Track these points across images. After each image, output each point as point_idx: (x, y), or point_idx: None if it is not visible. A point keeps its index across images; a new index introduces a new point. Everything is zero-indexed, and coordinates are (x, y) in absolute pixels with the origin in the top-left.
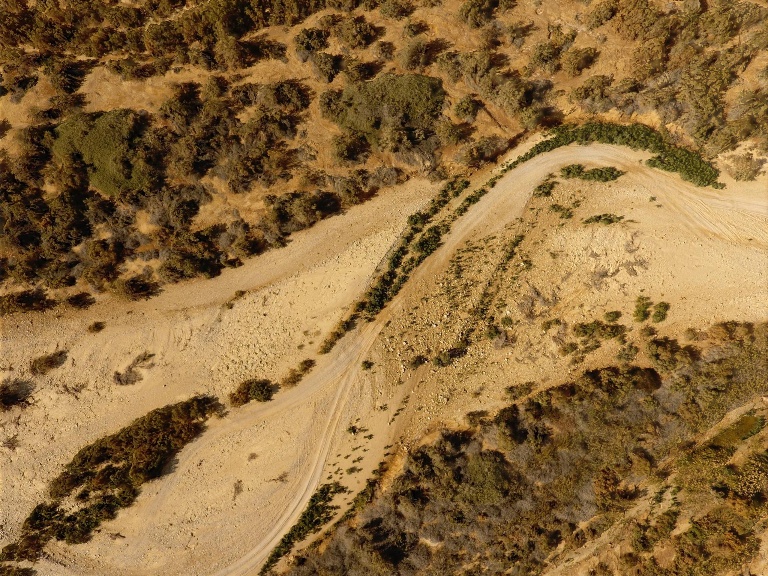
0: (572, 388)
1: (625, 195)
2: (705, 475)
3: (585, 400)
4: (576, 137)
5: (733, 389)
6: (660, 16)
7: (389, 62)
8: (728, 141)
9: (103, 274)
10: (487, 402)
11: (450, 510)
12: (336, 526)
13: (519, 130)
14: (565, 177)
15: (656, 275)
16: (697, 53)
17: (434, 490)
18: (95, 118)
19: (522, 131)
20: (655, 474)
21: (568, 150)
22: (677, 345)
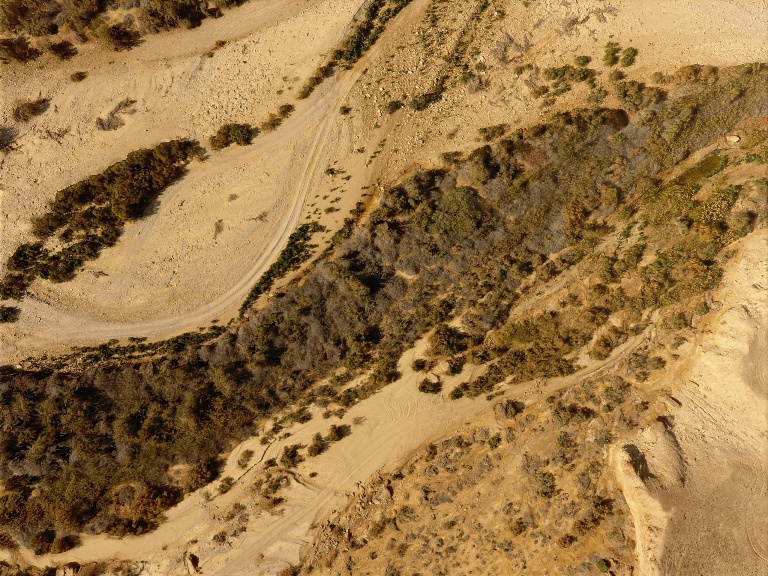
0: (543, 127)
1: None
2: (670, 208)
3: (555, 133)
4: None
5: (697, 123)
6: None
7: None
8: None
9: (85, 21)
10: (461, 143)
11: (425, 242)
12: (315, 262)
13: None
14: None
15: (625, 21)
16: None
17: (409, 221)
18: None
19: None
20: (623, 208)
21: None
22: None
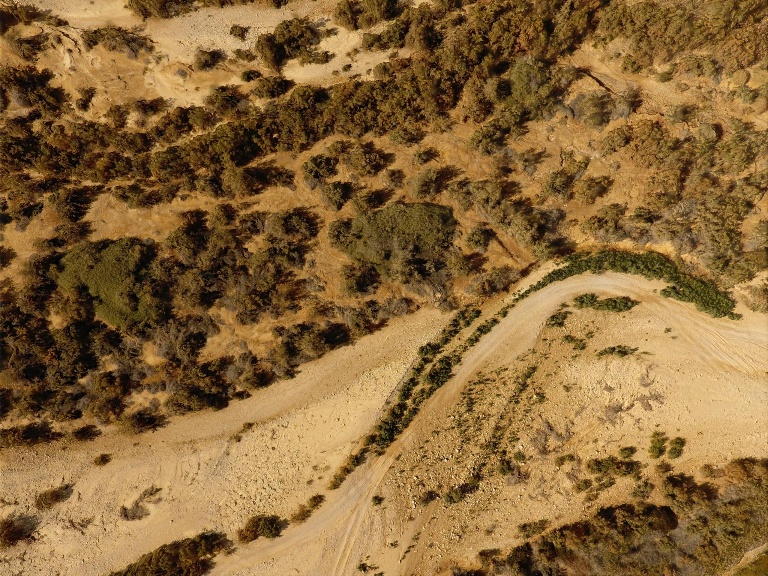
0: (586, 527)
1: (639, 326)
2: None
3: (600, 543)
4: (589, 267)
5: (751, 531)
6: (675, 148)
7: (399, 190)
8: (745, 276)
9: (109, 408)
10: (500, 540)
11: None
12: None
13: (531, 260)
14: (578, 307)
15: (672, 410)
16: (713, 184)
17: None
18: (101, 250)
19: (534, 261)
20: None
21: (581, 279)
22: (693, 482)
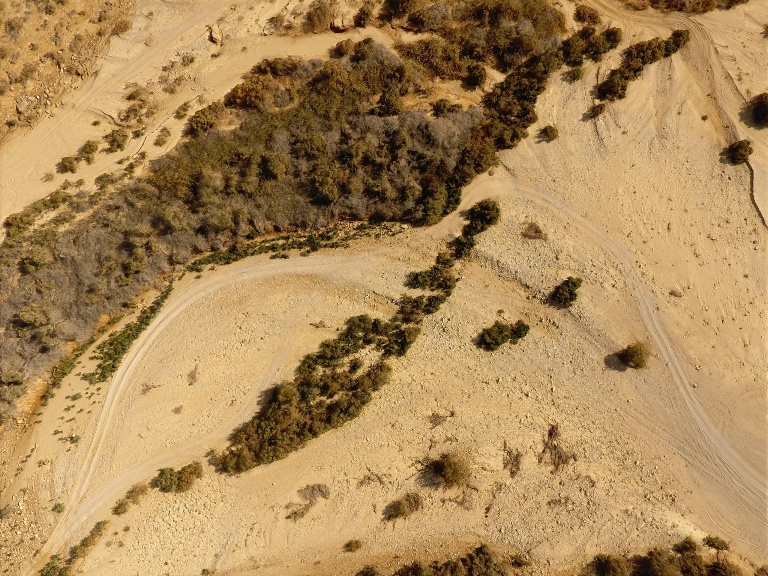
0: None
1: None
2: None
3: None
4: None
5: None
6: None
7: None
8: None
9: None
10: None
11: None
12: (92, 340)
13: None
14: None
15: None
16: None
17: None
18: None
19: None
20: None
21: None
22: None
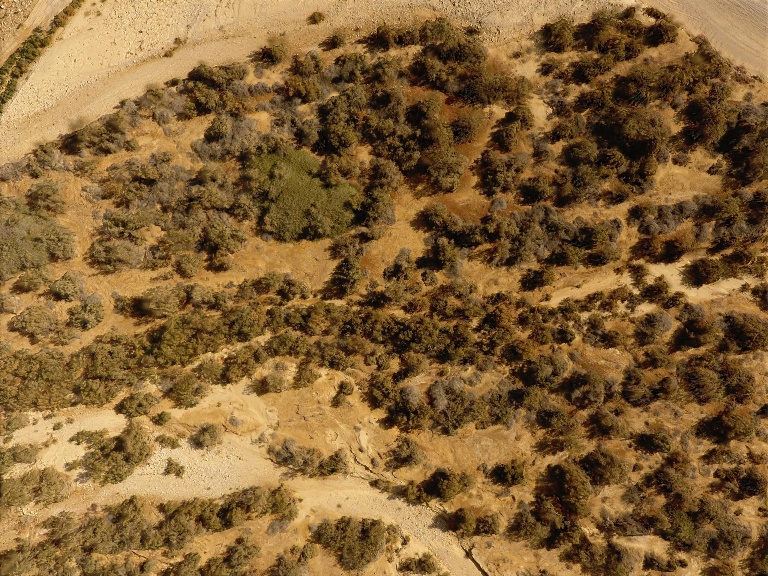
0: None
1: None
2: None
3: None
4: None
5: None
6: None
7: (5, 293)
8: None
9: None
10: None
11: None
12: None
13: None
14: None
15: None
16: None
17: None
18: None
19: None
20: None
21: None
22: None
